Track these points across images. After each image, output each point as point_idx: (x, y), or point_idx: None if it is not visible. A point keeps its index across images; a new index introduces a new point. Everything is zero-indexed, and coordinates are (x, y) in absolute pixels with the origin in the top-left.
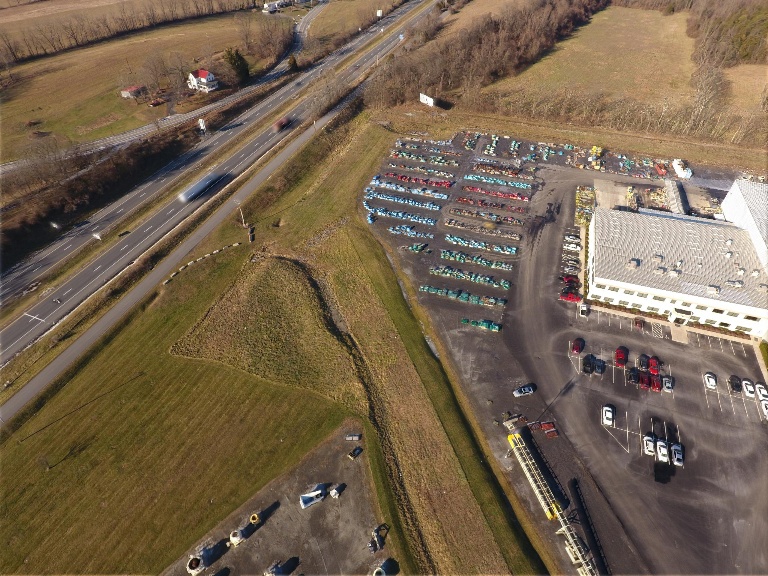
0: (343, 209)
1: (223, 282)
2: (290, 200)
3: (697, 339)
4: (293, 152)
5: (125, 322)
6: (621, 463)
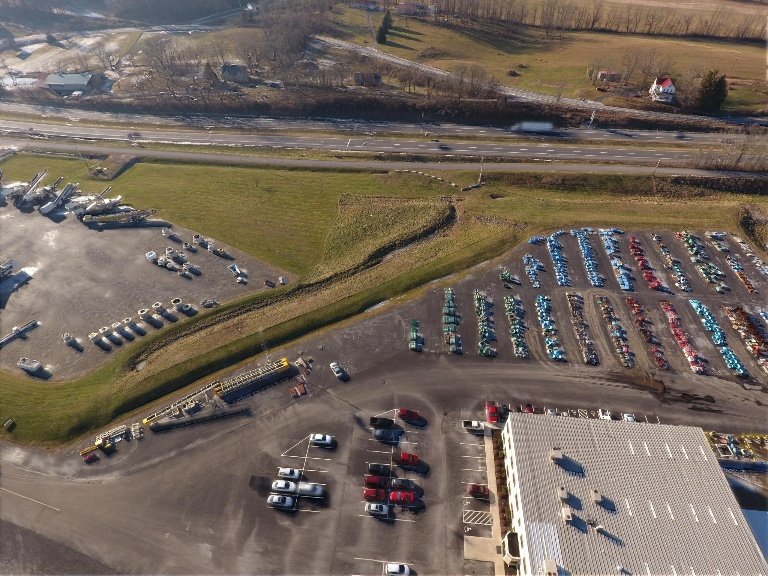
0: (538, 221)
1: (412, 193)
2: (536, 194)
3: (480, 575)
4: (607, 171)
5: (358, 171)
6: (269, 447)
